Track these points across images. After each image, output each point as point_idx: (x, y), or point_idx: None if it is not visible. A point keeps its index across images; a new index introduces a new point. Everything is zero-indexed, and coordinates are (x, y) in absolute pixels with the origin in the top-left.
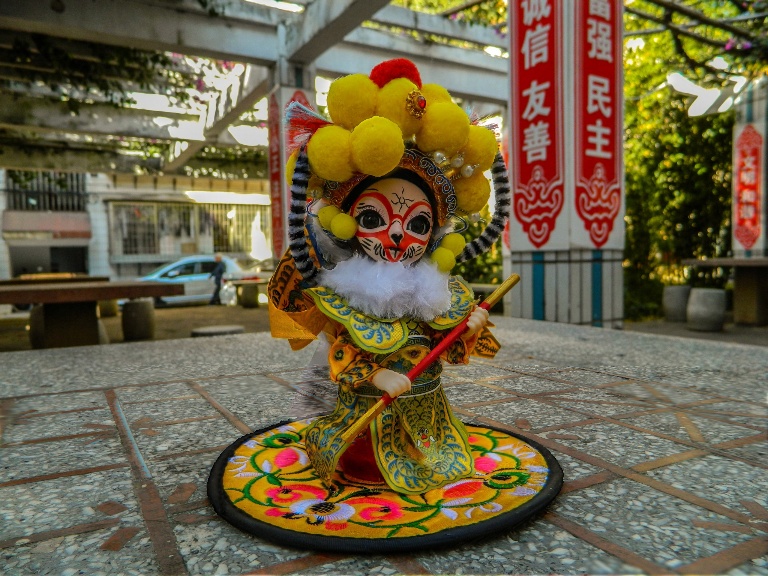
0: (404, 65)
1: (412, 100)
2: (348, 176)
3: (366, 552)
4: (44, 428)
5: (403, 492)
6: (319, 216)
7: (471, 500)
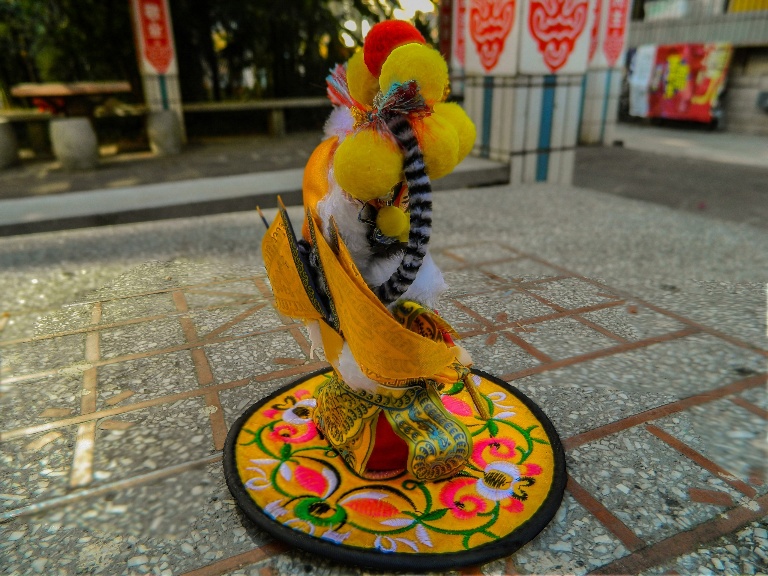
0: None
1: None
2: None
3: None
4: None
5: None
6: (399, 222)
7: None
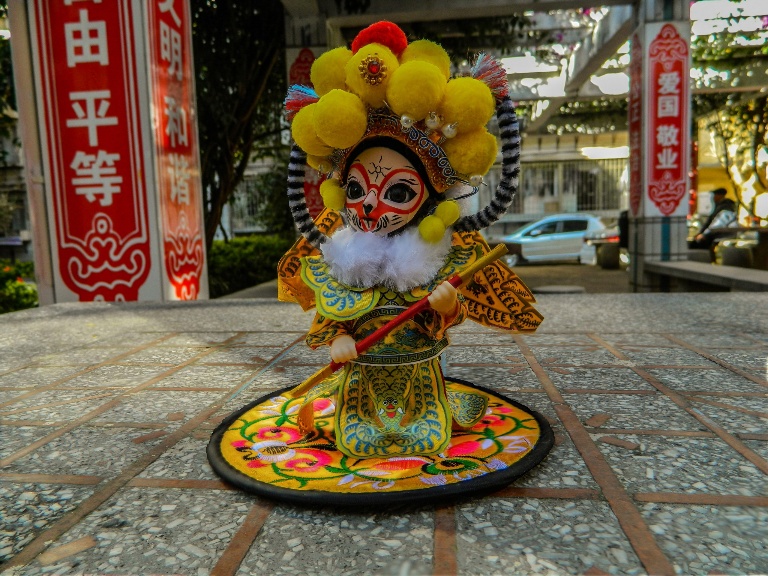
0: (376, 29)
1: (366, 67)
2: (325, 150)
3: (244, 489)
4: (229, 356)
5: (346, 453)
6: None
7: (384, 475)
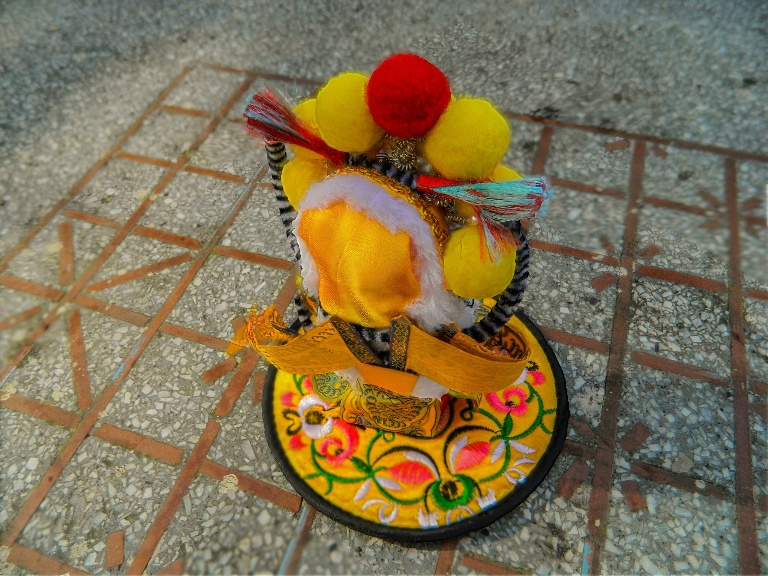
0: None
1: None
2: None
3: None
4: None
5: None
6: None
7: None
